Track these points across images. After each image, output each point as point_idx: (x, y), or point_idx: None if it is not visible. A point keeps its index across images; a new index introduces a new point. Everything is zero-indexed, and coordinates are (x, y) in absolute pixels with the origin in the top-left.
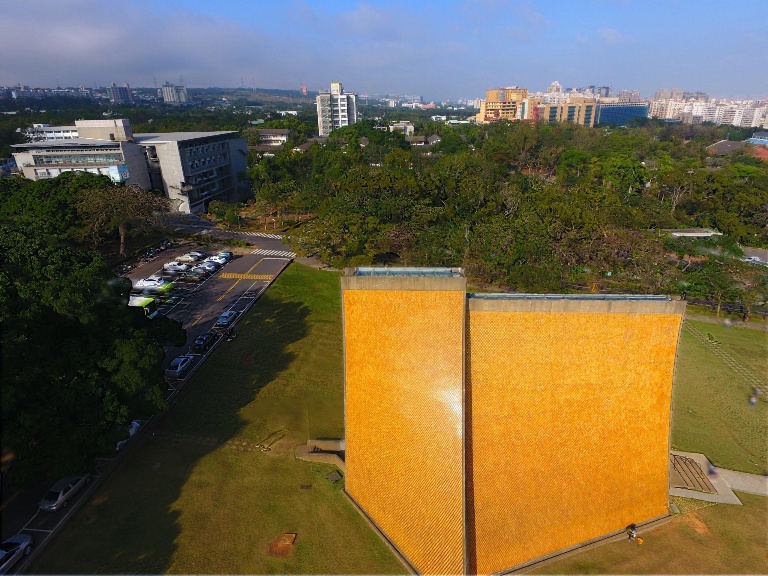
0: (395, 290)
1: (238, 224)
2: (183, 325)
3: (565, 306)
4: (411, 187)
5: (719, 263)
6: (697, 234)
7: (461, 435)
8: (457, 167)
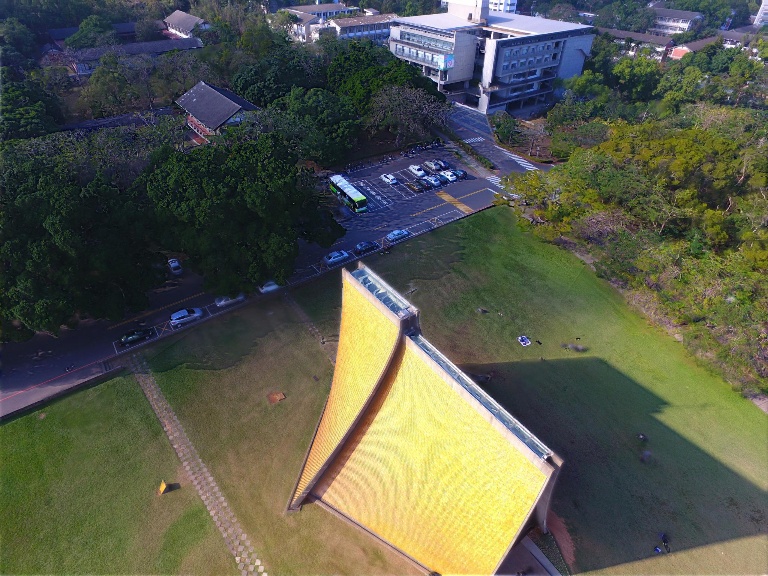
0: (366, 298)
1: (509, 141)
2: (370, 226)
3: (461, 392)
4: (673, 170)
5: None
6: None
7: (354, 418)
8: None
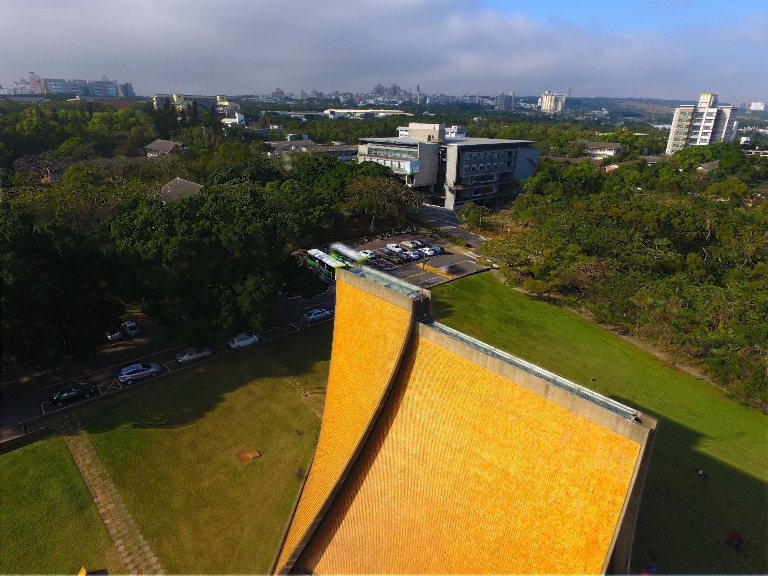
0: (366, 292)
1: (479, 227)
2: None
3: (500, 368)
4: (647, 222)
5: None
6: None
7: (357, 443)
8: None
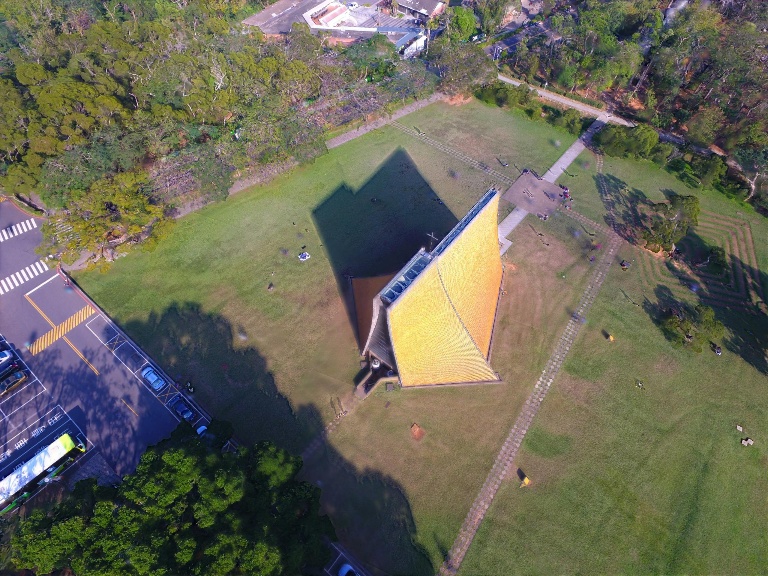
0: None
1: None
2: (126, 420)
3: None
4: (113, 108)
5: (386, 60)
6: (322, 5)
7: (460, 322)
8: (41, 4)
